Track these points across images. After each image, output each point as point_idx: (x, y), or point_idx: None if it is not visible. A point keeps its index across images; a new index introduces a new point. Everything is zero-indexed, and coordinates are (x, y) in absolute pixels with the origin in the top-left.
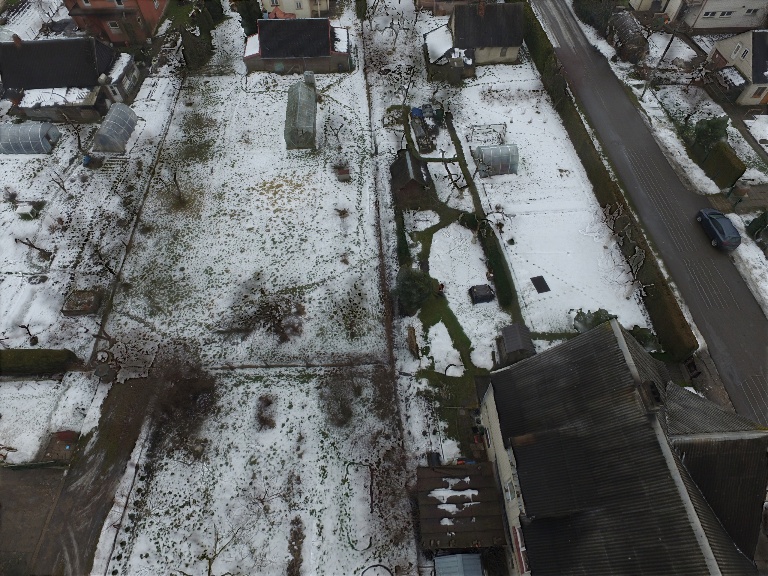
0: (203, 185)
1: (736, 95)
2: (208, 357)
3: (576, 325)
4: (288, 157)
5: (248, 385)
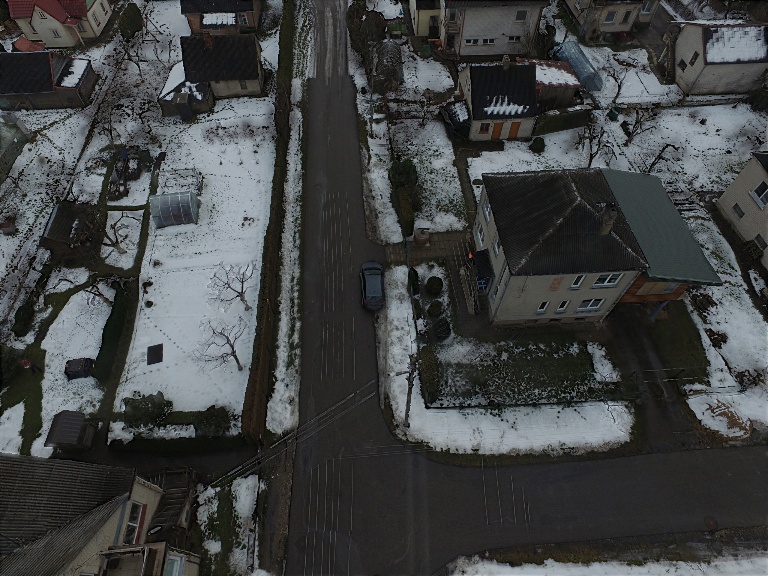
0: None
1: (466, 130)
2: None
3: None
4: None
5: None
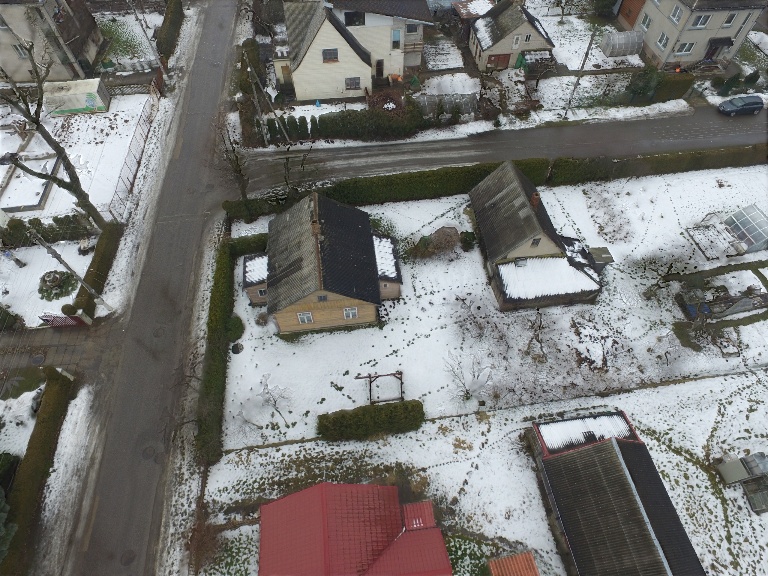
0: None
1: None
2: None
3: None
4: None
5: None
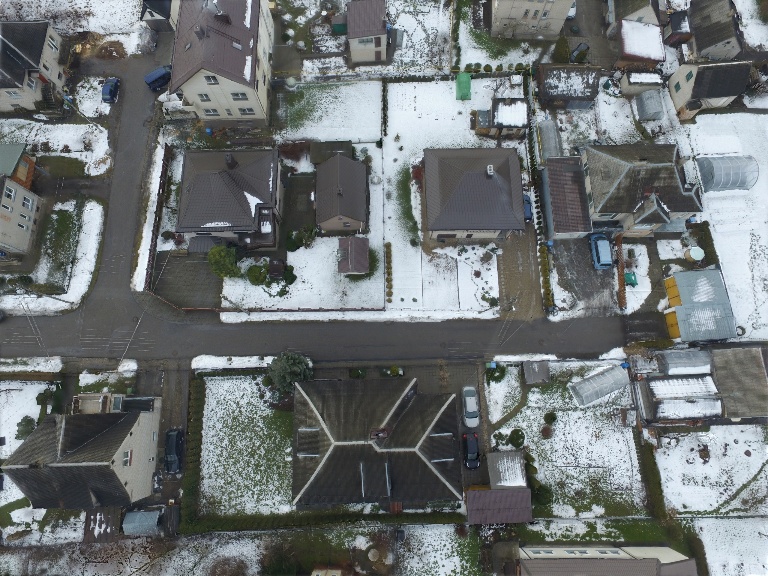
0: None
1: None
2: None
3: None
4: None
5: None
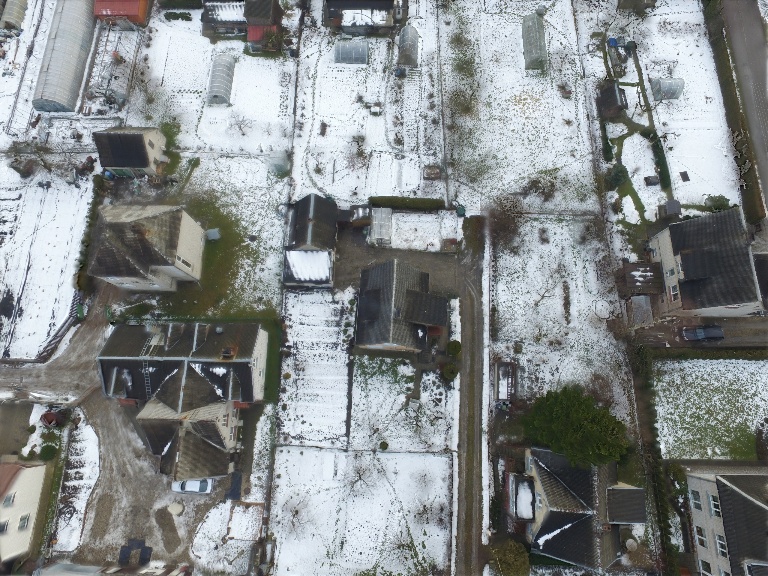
0: (476, 96)
1: None
2: (508, 207)
3: (706, 203)
4: (527, 76)
5: (532, 222)
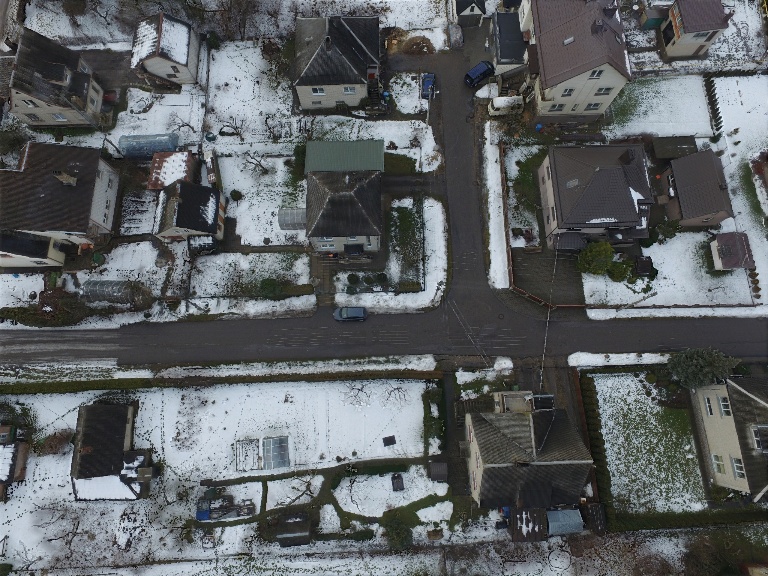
0: None
1: None
2: None
3: None
4: None
5: None
